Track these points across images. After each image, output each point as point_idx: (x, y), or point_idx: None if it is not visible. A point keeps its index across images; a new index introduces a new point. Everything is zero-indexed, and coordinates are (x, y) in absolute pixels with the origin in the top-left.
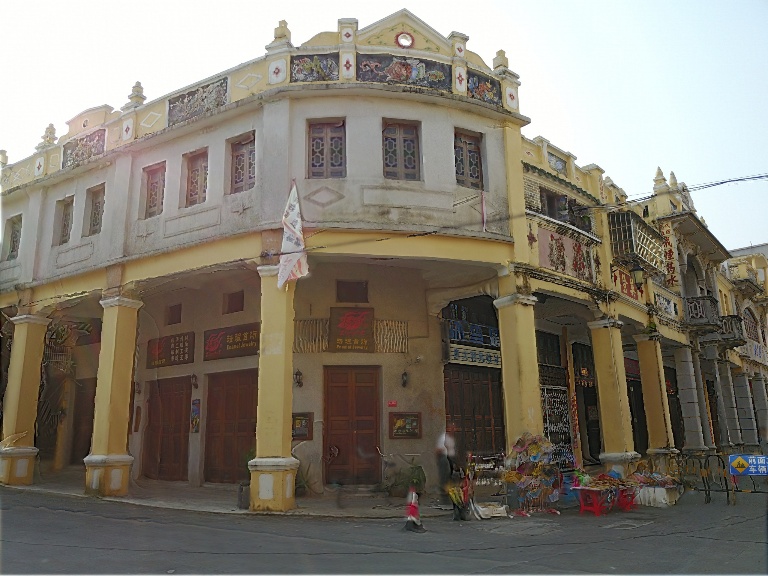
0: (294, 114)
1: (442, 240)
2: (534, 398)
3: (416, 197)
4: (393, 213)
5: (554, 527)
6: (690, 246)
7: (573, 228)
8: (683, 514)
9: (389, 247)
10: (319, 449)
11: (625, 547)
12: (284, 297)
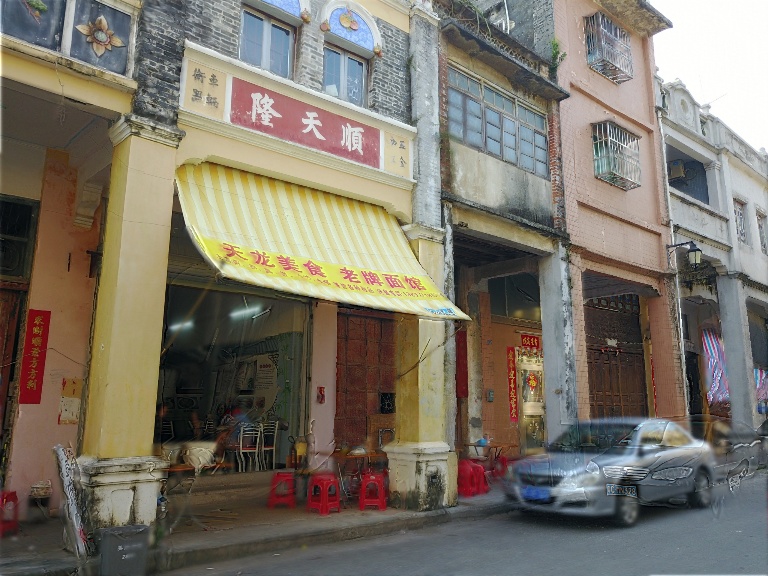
0: None
1: None
2: None
3: None
4: None
5: None
6: None
7: None
8: None
9: None
10: (765, 417)
11: None
12: None
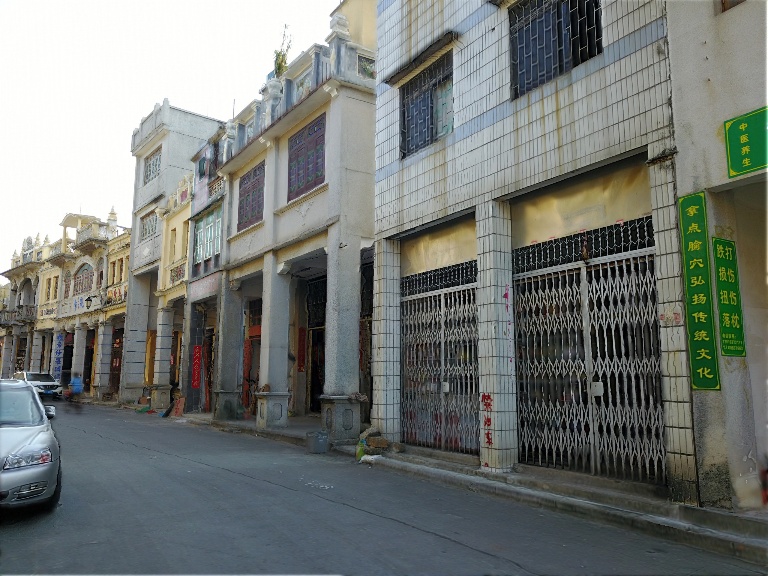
0: None
1: None
2: None
3: None
4: None
5: None
6: (21, 277)
7: None
8: None
9: None
10: None
11: None
12: None
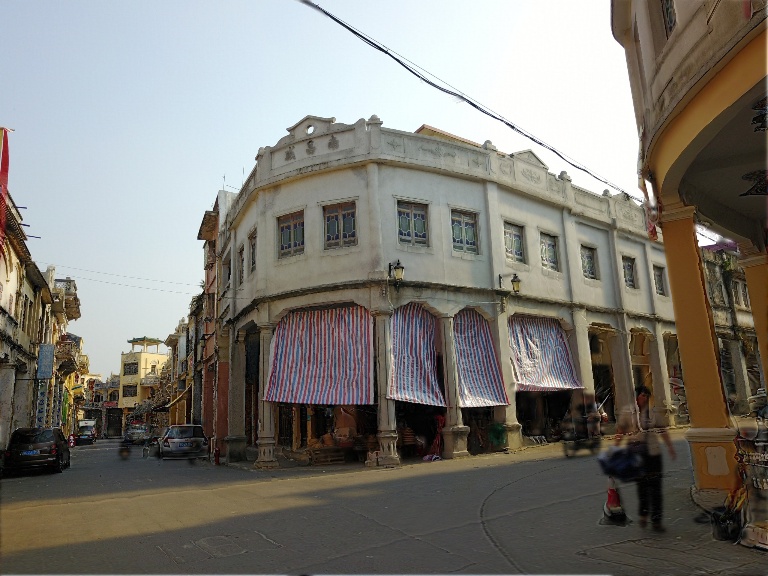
0: (632, 44)
1: (709, 89)
2: None
3: (675, 55)
4: (666, 98)
5: (673, 570)
6: None
7: None
8: None
9: (674, 146)
10: None
11: (464, 573)
12: (662, 250)
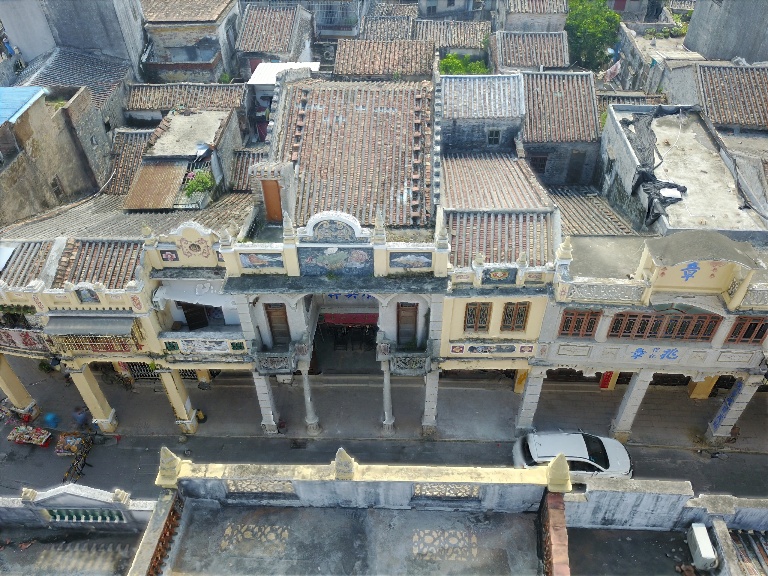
0: None
1: None
2: (7, 391)
3: None
4: None
5: None
6: None
7: (10, 329)
8: (32, 465)
9: None
10: None
11: None
12: None
